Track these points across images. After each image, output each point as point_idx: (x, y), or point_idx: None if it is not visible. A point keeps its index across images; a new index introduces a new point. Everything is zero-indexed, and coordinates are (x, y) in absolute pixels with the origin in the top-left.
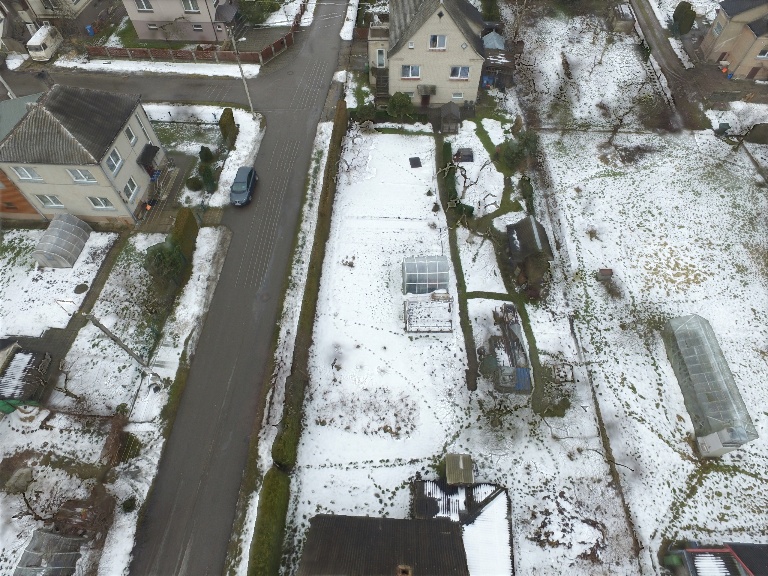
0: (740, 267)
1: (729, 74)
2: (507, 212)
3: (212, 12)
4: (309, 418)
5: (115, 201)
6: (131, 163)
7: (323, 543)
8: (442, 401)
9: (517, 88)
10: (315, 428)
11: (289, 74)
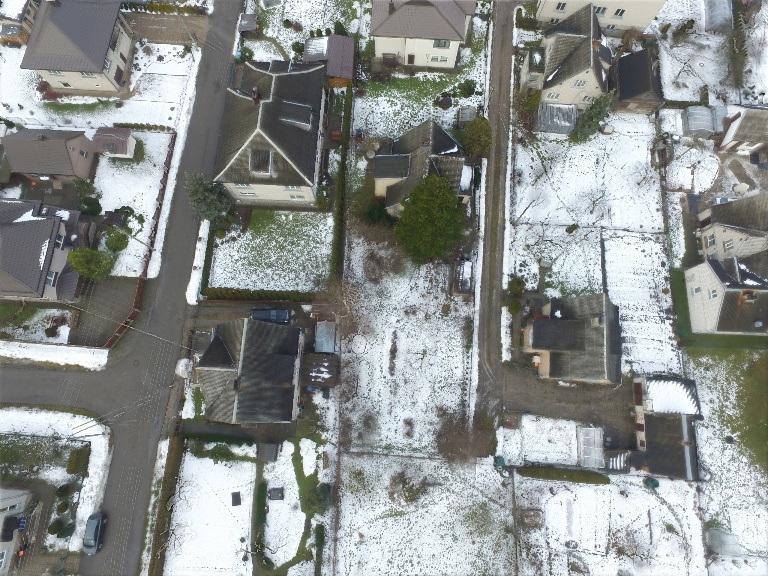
0: None
1: (537, 373)
2: (300, 561)
3: (52, 295)
4: None
5: None
6: None
7: None
8: None
9: (341, 389)
10: None
11: (135, 365)
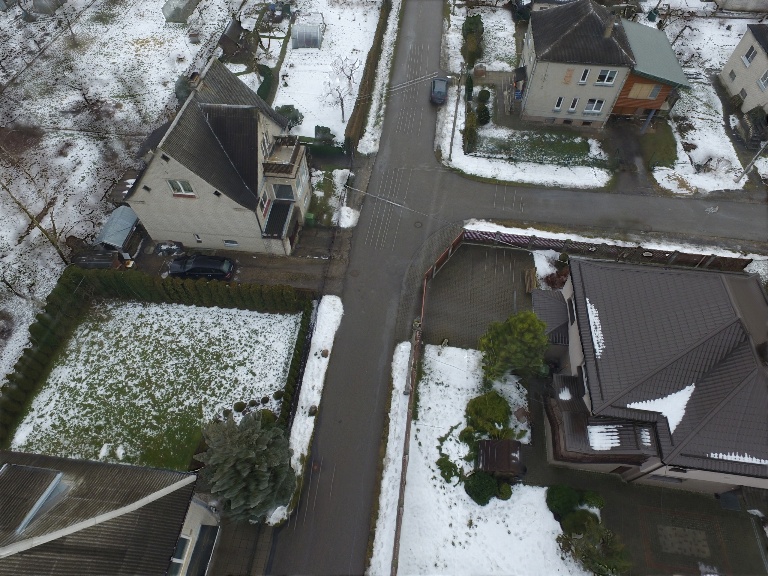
0: None
1: None
2: None
3: None
4: (380, 3)
5: None
6: None
7: None
8: (315, 6)
9: None
10: None
11: (420, 223)
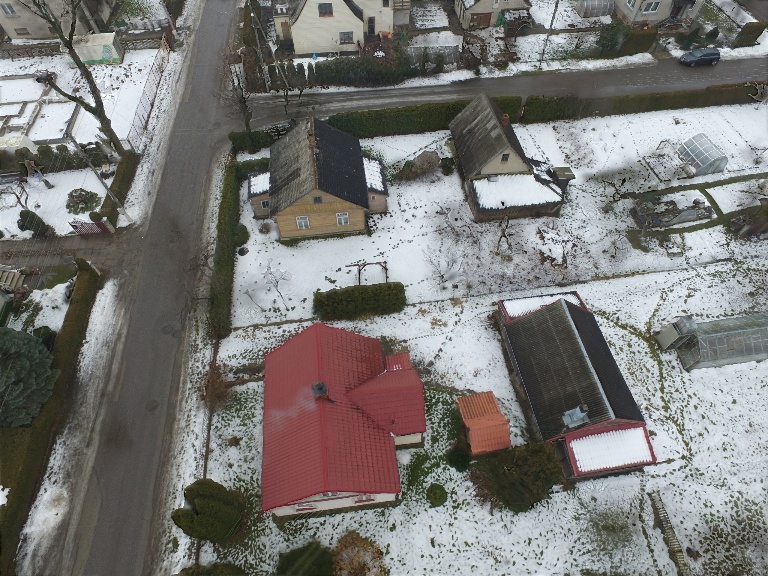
0: None
1: None
2: None
3: None
4: None
5: (637, 3)
6: None
7: (499, 110)
8: (603, 180)
9: None
10: (550, 127)
11: None
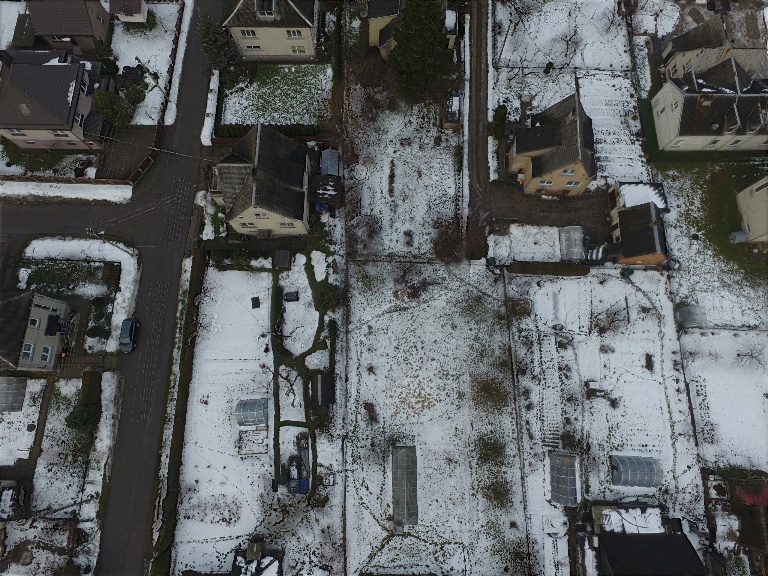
0: (460, 394)
1: (522, 189)
2: (316, 350)
3: (79, 134)
4: (181, 515)
5: None
6: (41, 339)
7: None
8: (256, 501)
9: (346, 210)
10: (184, 521)
11: (157, 197)
